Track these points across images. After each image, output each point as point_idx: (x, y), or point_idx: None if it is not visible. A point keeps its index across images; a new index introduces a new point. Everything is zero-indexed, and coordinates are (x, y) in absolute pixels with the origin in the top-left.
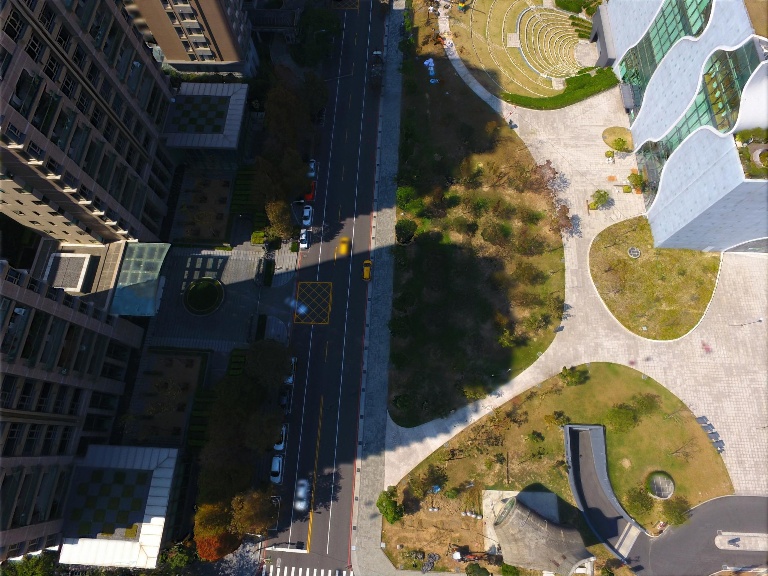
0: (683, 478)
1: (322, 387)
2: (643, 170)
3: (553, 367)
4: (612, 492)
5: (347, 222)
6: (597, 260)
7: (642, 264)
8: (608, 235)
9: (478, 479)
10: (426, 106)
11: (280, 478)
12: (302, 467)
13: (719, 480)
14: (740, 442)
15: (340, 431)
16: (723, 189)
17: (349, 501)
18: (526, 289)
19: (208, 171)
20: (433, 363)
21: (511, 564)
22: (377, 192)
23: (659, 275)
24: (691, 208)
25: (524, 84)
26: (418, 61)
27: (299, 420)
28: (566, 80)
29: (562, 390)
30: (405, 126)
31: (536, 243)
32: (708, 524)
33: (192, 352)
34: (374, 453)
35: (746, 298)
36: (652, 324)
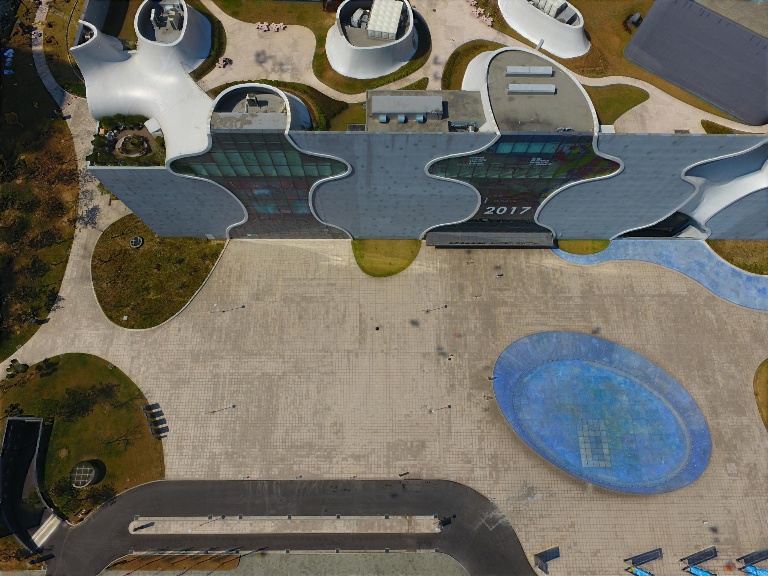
0: (116, 465)
1: None
2: None
3: (27, 360)
4: (36, 483)
5: None
6: (101, 251)
7: (142, 253)
8: (120, 225)
9: None
10: None
11: None
12: None
13: (151, 466)
14: (185, 427)
15: None
16: None
17: None
18: (25, 282)
19: None
20: None
21: None
22: None
23: None
24: None
25: None
26: (3, 52)
27: None
28: None
29: (26, 382)
30: None
31: (49, 235)
32: (128, 510)
33: None
34: None
35: (237, 284)
36: (134, 313)
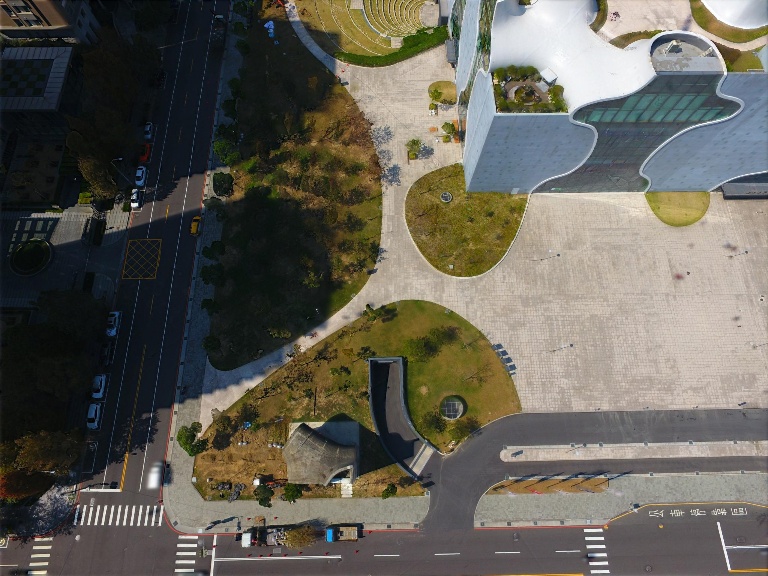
0: (475, 400)
1: (145, 338)
2: (463, 121)
3: (365, 307)
4: (408, 416)
5: (181, 181)
6: (412, 206)
7: (453, 208)
8: (424, 182)
9: (287, 413)
10: (265, 67)
11: (97, 424)
12: (121, 413)
13: (508, 400)
14: (530, 365)
15: (160, 378)
16: (487, 126)
17: (164, 442)
18: (344, 236)
19: (42, 136)
20: (253, 310)
21: (290, 482)
22: (212, 151)
23: (465, 216)
24: (477, 149)
25: (363, 44)
26: (260, 24)
27: (120, 370)
28: (403, 39)
29: (371, 327)
30: (229, 84)
31: (357, 193)
32: (495, 440)
33: (14, 310)
34: (191, 396)
35: (548, 235)
36: (458, 262)
